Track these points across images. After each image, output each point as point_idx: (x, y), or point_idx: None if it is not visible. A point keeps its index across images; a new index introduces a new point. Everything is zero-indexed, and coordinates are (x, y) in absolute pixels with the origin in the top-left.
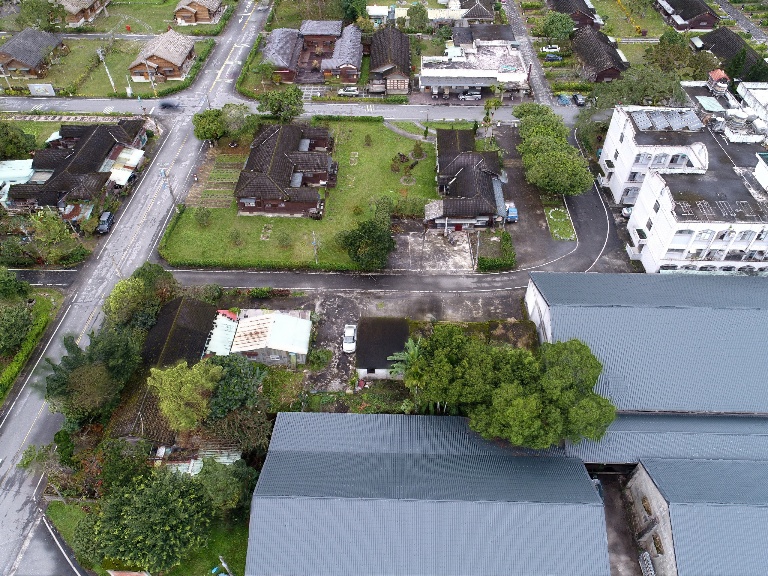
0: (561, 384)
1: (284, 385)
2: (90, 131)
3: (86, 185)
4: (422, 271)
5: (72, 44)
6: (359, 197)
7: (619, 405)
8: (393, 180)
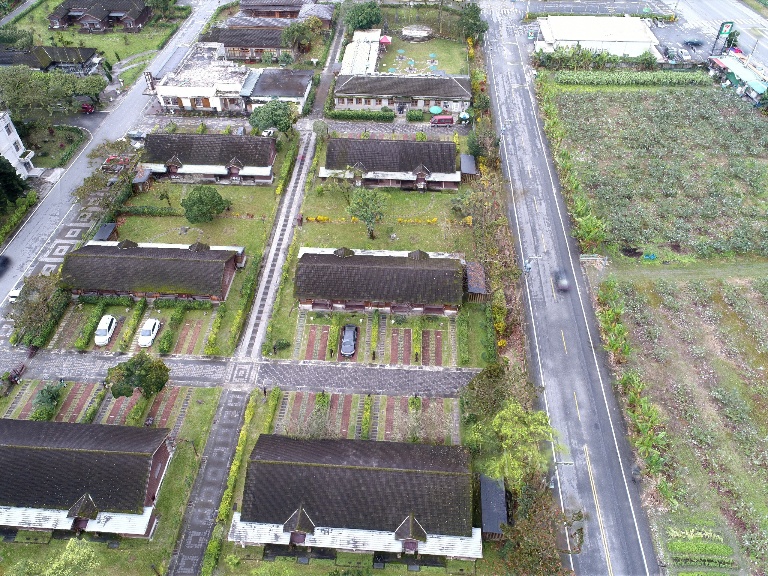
0: None
1: None
2: None
3: None
4: None
5: None
6: None
7: None
8: None
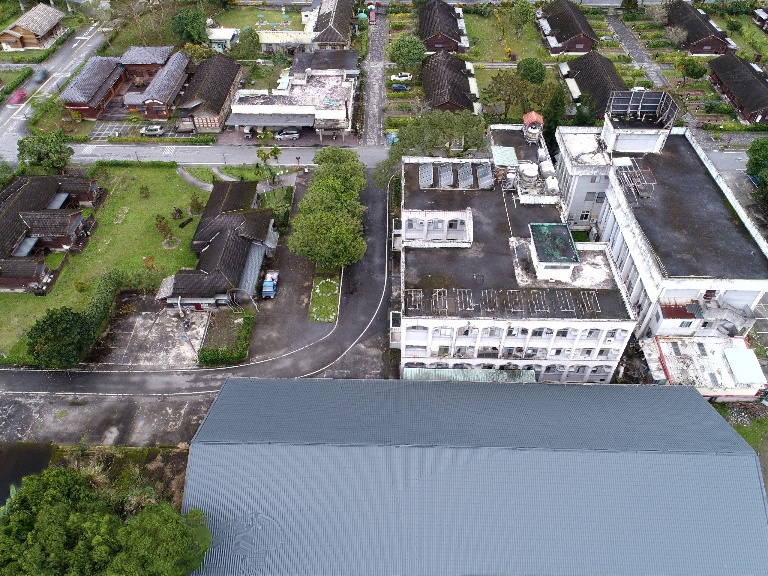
0: None
1: None
2: None
3: None
4: (133, 366)
5: None
6: (103, 265)
7: None
8: (154, 242)
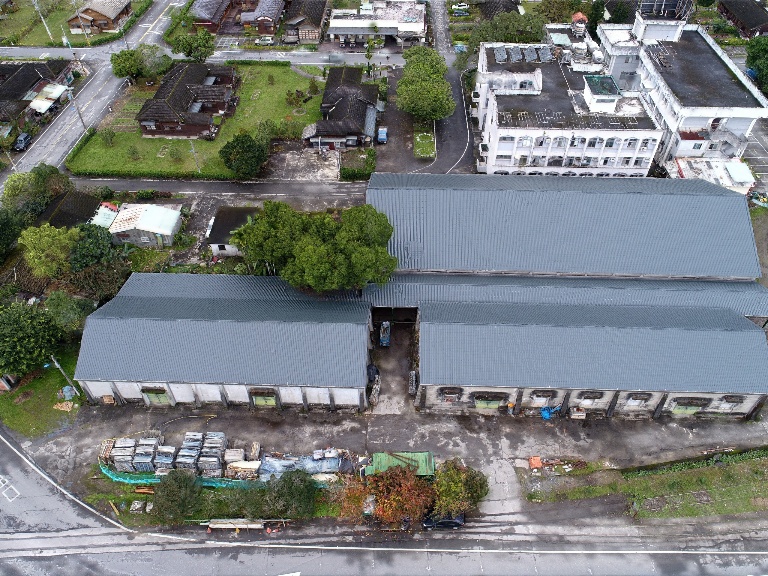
0: (348, 236)
1: (150, 261)
2: (18, 68)
3: (6, 109)
4: (292, 180)
5: (22, 3)
6: (252, 124)
7: (414, 265)
8: (286, 111)
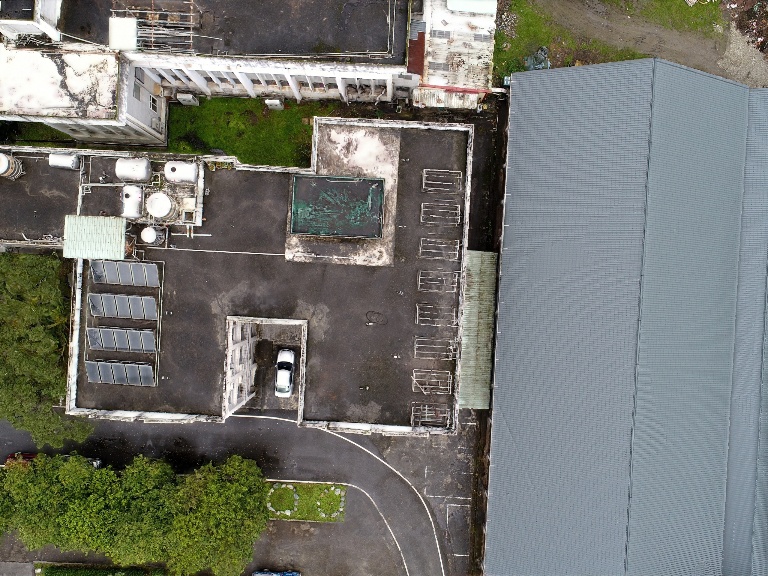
0: None
1: None
2: None
3: None
4: None
5: None
6: None
7: (718, 572)
8: None
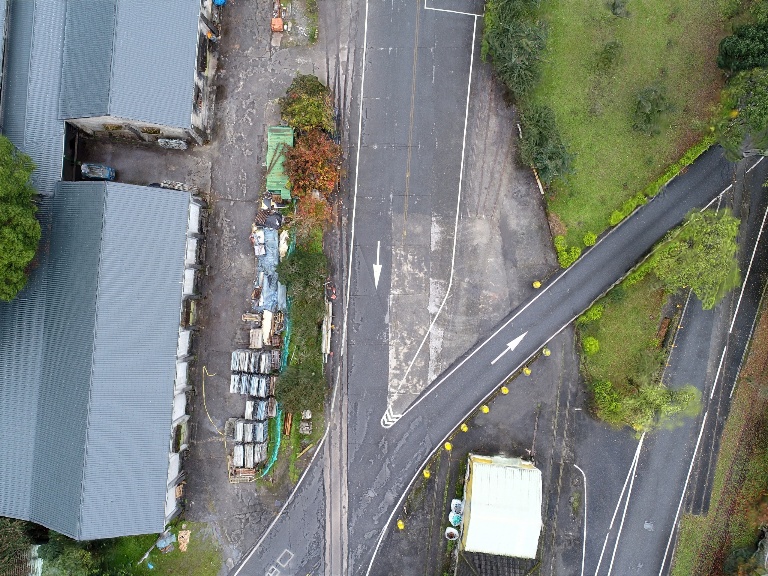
0: None
1: None
2: None
3: None
4: None
5: None
6: None
7: None
8: None
